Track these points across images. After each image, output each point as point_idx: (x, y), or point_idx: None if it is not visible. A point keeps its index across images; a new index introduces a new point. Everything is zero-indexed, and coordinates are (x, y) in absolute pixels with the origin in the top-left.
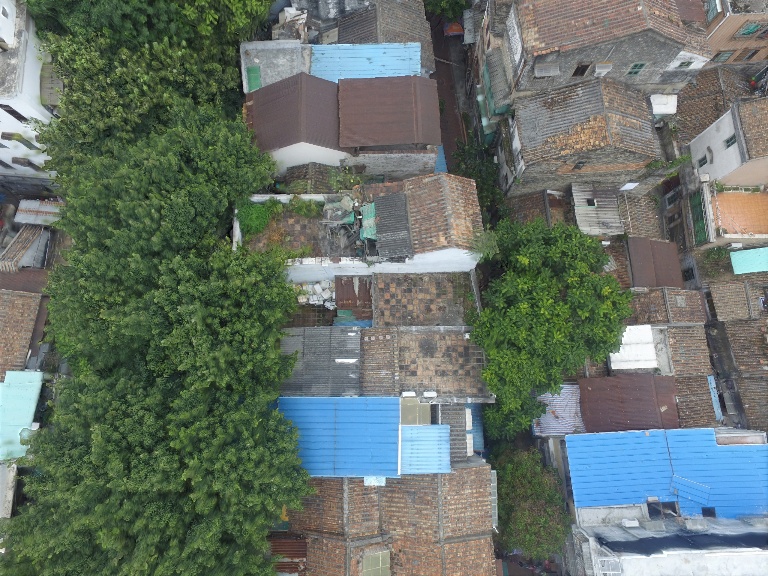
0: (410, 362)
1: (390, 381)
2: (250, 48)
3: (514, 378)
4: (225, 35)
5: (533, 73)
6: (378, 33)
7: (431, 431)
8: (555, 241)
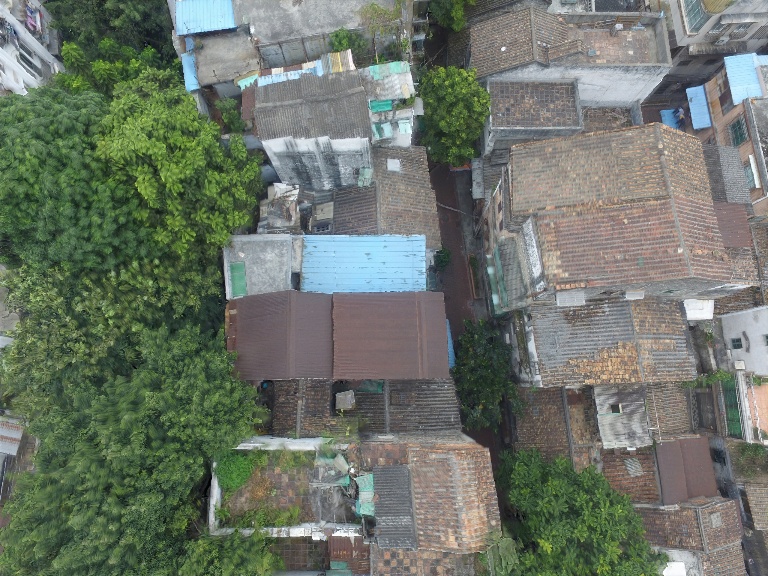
0: None
1: None
2: (234, 240)
3: None
4: (205, 237)
5: None
6: (378, 217)
7: None
8: (581, 508)
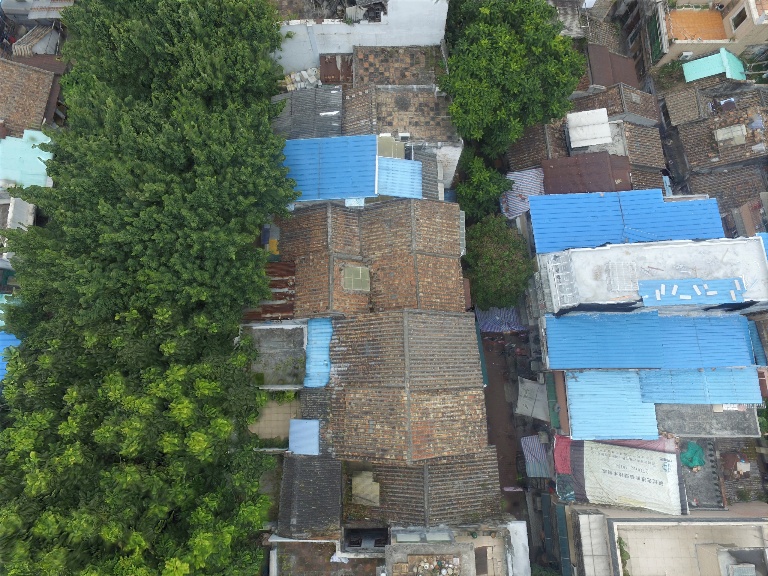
0: (387, 115)
1: (368, 127)
2: None
3: (477, 107)
4: None
5: None
6: None
7: (405, 164)
8: (515, 4)
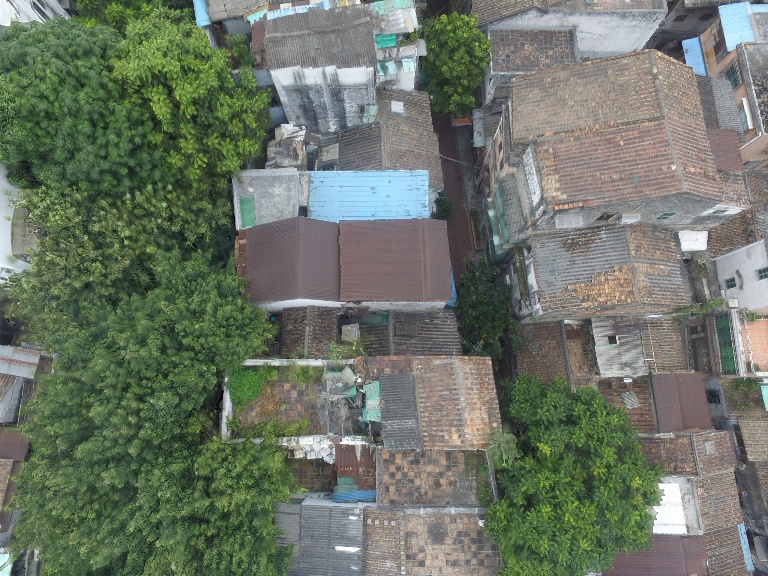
0: (418, 550)
1: (396, 575)
2: (243, 175)
3: None
4: (216, 169)
5: (553, 219)
6: (382, 155)
7: None
8: (578, 418)
